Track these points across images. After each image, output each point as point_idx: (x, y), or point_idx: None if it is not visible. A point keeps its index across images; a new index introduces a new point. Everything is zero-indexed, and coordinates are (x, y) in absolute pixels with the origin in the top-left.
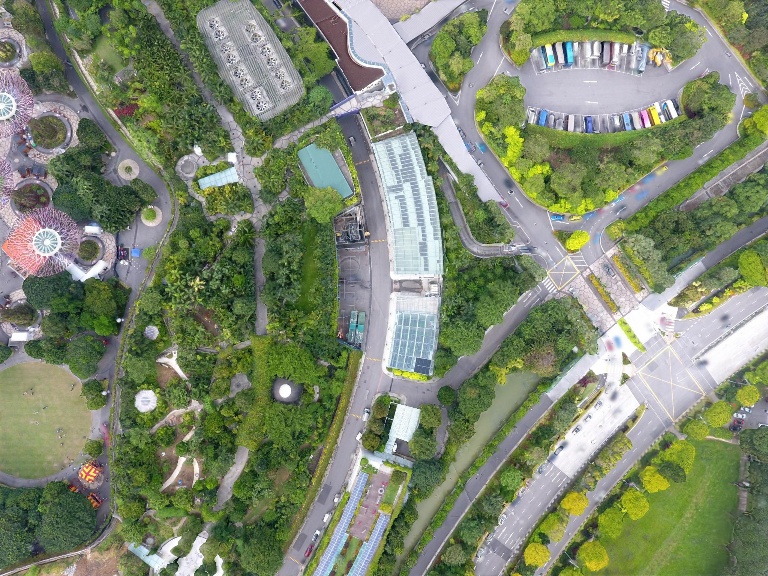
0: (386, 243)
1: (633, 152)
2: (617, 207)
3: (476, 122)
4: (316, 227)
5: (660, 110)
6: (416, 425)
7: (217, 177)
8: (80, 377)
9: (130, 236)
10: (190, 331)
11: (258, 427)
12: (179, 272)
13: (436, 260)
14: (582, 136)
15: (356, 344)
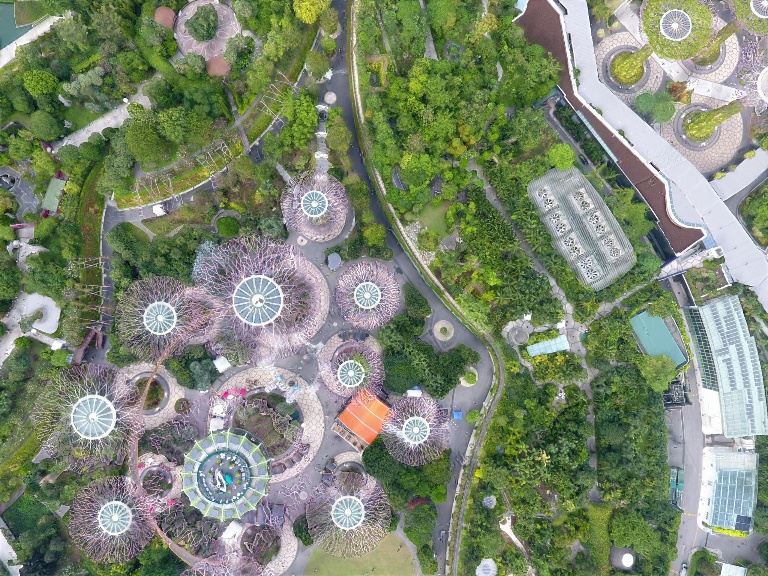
0: (697, 398)
1: None
2: None
3: None
4: None
5: None
6: None
7: (546, 344)
8: (416, 544)
9: (448, 397)
10: (529, 500)
11: None
12: (526, 447)
13: (761, 421)
14: None
15: (673, 500)
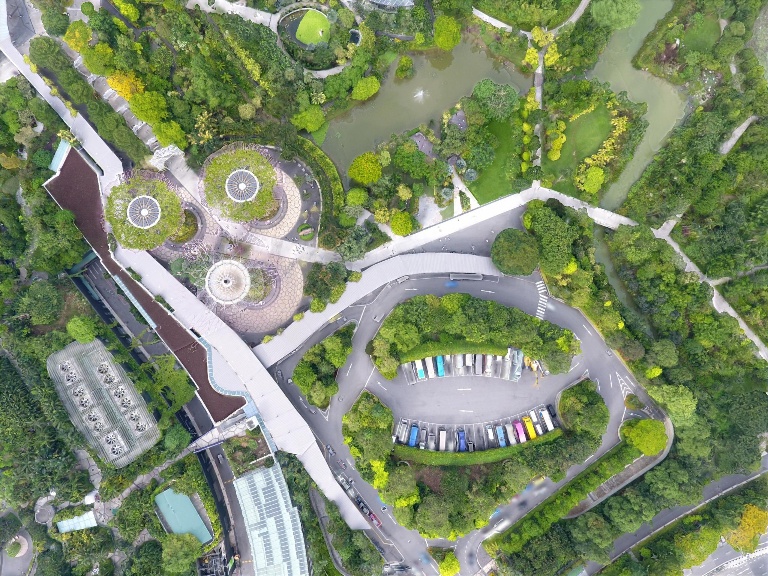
0: None
1: (504, 476)
2: (494, 519)
3: None
4: None
5: (536, 419)
6: None
7: (75, 521)
8: None
9: None
10: None
11: None
12: None
13: None
14: (452, 457)
15: None
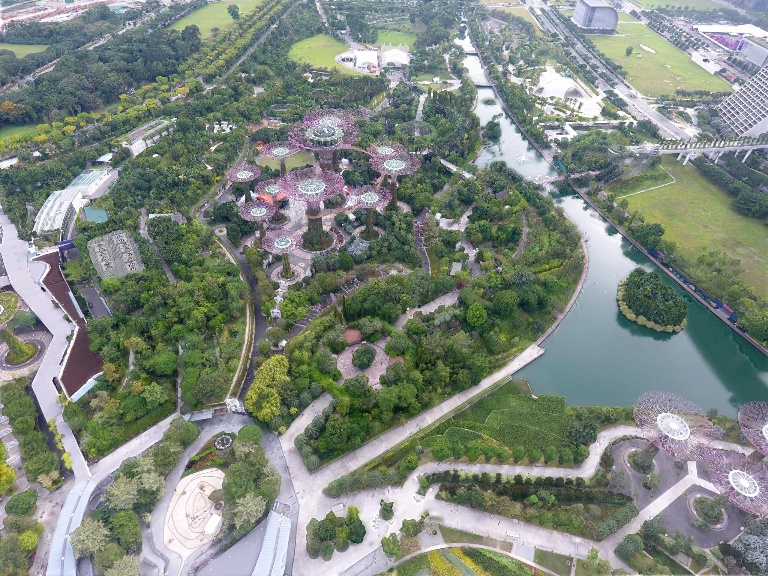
0: None
1: None
2: None
3: None
4: None
5: None
6: None
7: None
8: None
9: None
10: None
11: None
12: None
13: None
14: None
15: None
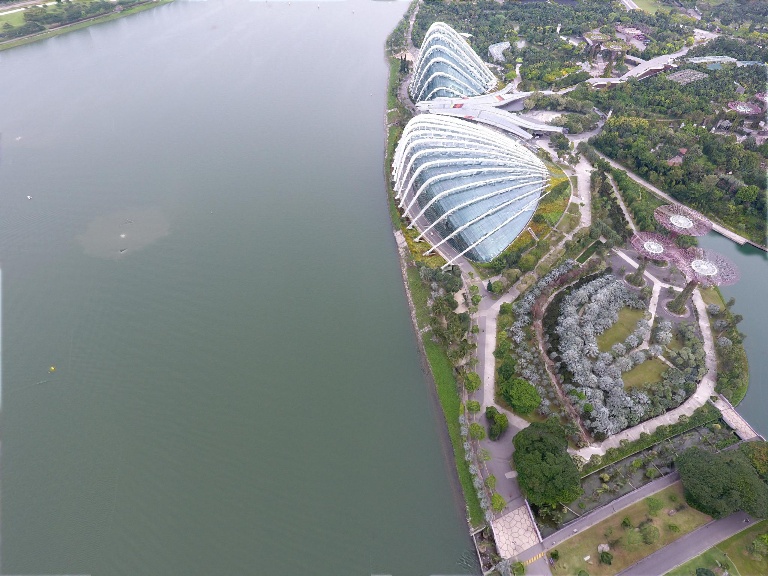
0: None
1: None
2: None
3: None
4: None
5: None
6: None
7: None
8: None
9: None
10: None
11: None
12: None
13: None
14: None
15: None
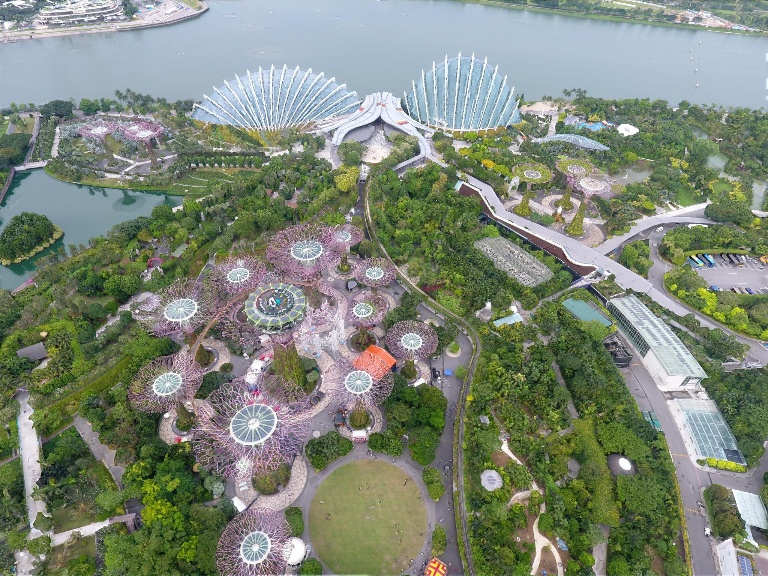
0: (643, 366)
1: None
2: None
3: (670, 293)
4: (592, 346)
5: None
6: (763, 511)
7: (506, 319)
8: (421, 463)
9: (439, 364)
10: (518, 418)
11: (611, 502)
12: (503, 369)
13: (696, 368)
14: (752, 296)
15: None
